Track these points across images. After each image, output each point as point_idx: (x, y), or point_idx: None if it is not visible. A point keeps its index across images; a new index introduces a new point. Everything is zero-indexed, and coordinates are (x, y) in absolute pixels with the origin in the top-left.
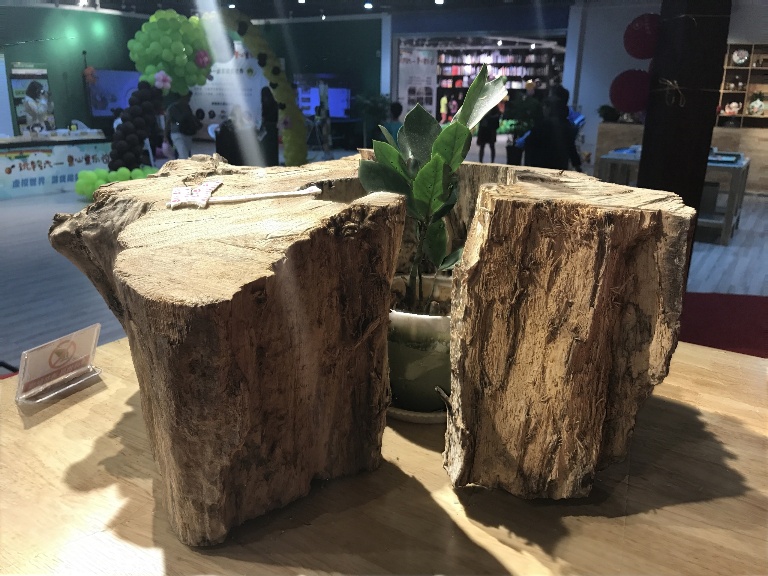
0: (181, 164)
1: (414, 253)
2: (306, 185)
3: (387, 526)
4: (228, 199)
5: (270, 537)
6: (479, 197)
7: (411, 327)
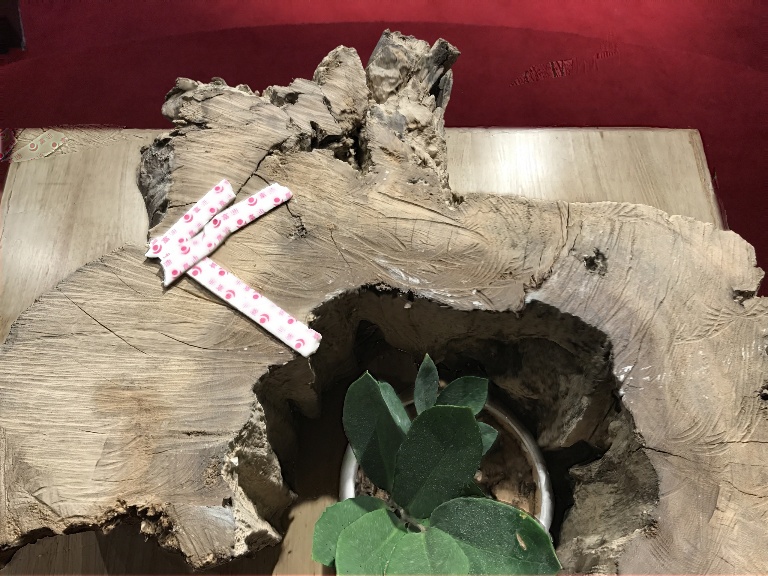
0: (339, 74)
1: (531, 397)
2: (364, 286)
3: None
4: (206, 285)
5: (129, 529)
6: None
7: None
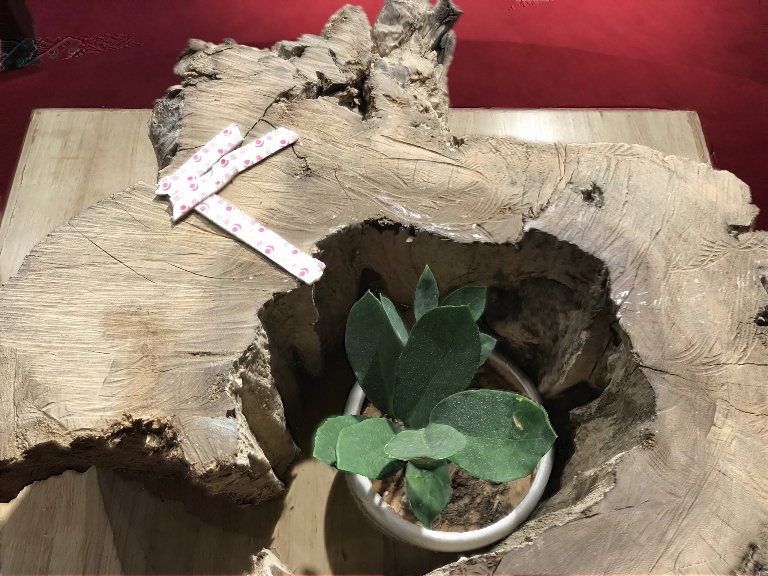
0: (344, 28)
1: (531, 343)
2: (366, 221)
3: (193, 562)
4: (213, 219)
5: (132, 485)
6: None
7: None
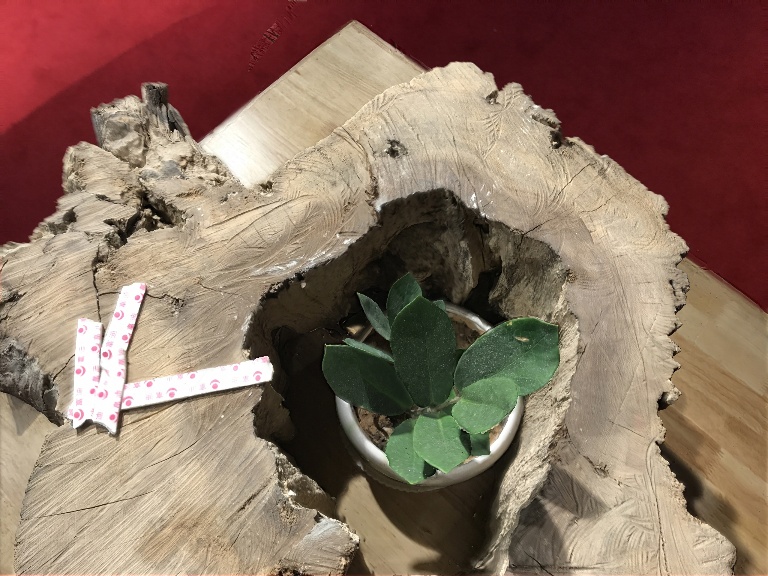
0: (90, 170)
1: (427, 277)
2: (261, 299)
3: None
4: (146, 403)
5: None
6: None
7: (387, 470)
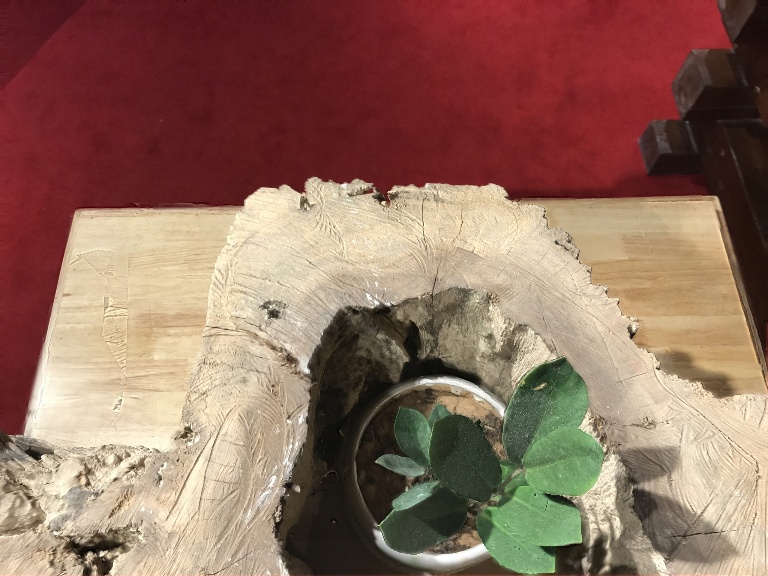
0: None
1: None
2: (275, 535)
3: None
4: None
5: None
6: None
7: None
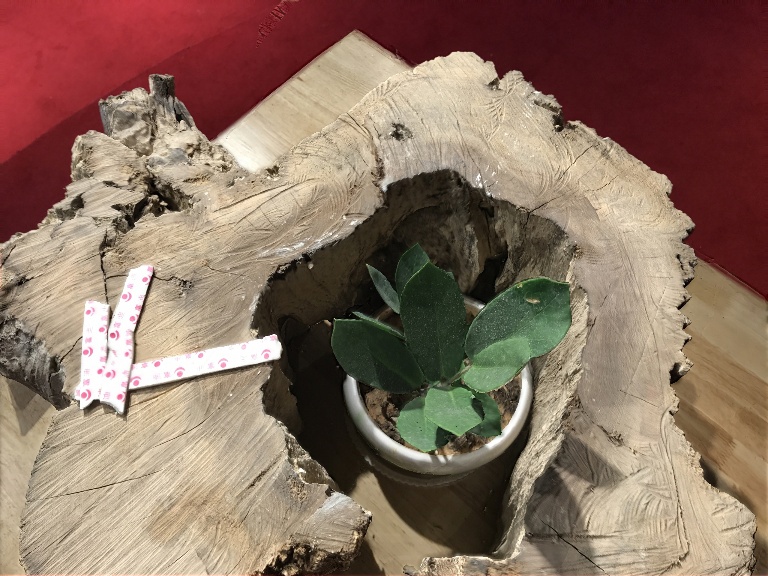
0: (98, 157)
1: None
2: (269, 280)
3: None
4: (154, 383)
5: None
6: (460, 571)
7: (396, 458)
